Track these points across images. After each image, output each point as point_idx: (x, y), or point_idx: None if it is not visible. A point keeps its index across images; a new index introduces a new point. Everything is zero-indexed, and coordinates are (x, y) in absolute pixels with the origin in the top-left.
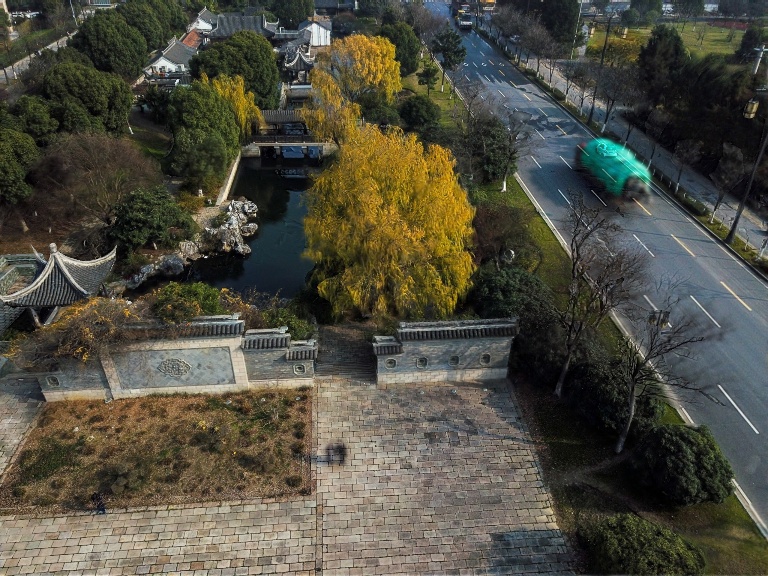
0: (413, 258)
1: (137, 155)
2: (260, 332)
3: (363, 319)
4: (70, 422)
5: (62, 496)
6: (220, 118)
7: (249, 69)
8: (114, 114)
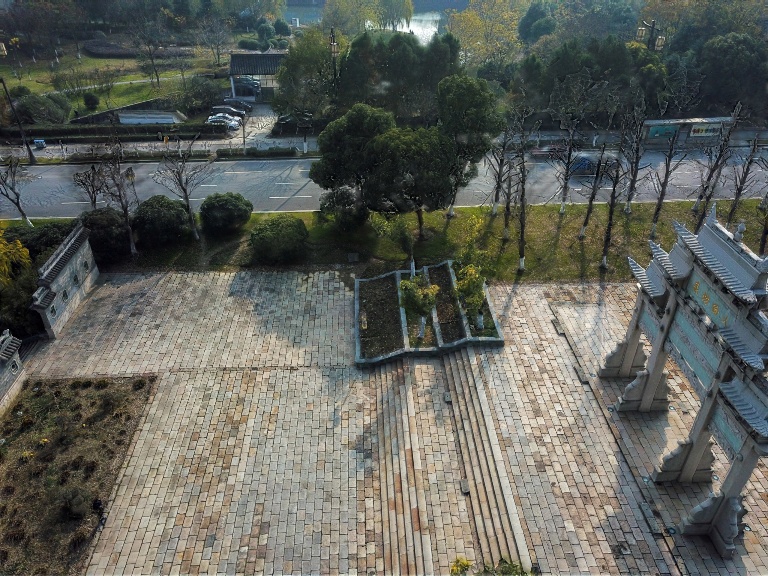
0: None
1: None
2: None
3: None
4: None
5: (59, 569)
6: None
7: None
8: None
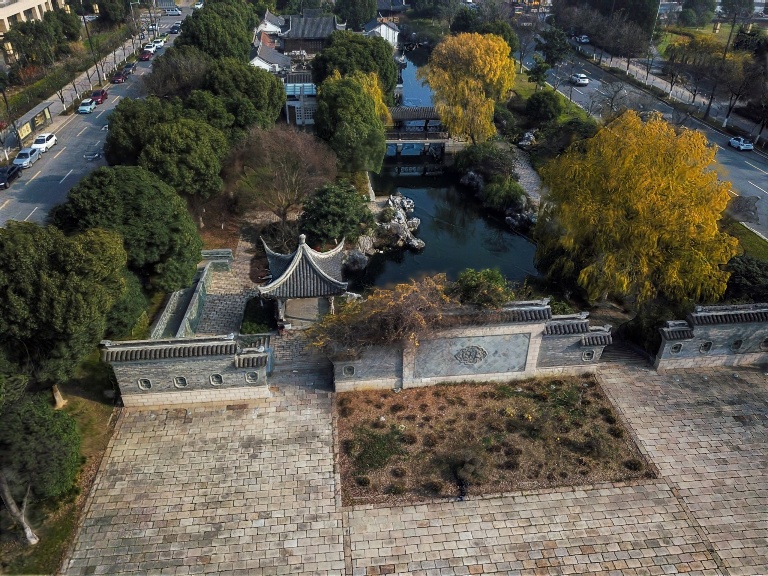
0: (664, 245)
1: (321, 149)
2: (562, 318)
3: (592, 308)
4: (372, 412)
5: (408, 484)
6: (371, 114)
7: (375, 66)
8: (271, 110)
